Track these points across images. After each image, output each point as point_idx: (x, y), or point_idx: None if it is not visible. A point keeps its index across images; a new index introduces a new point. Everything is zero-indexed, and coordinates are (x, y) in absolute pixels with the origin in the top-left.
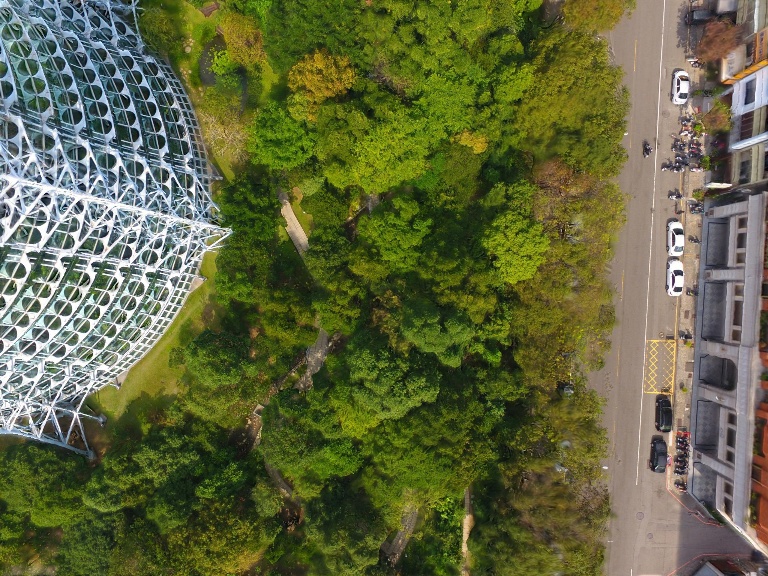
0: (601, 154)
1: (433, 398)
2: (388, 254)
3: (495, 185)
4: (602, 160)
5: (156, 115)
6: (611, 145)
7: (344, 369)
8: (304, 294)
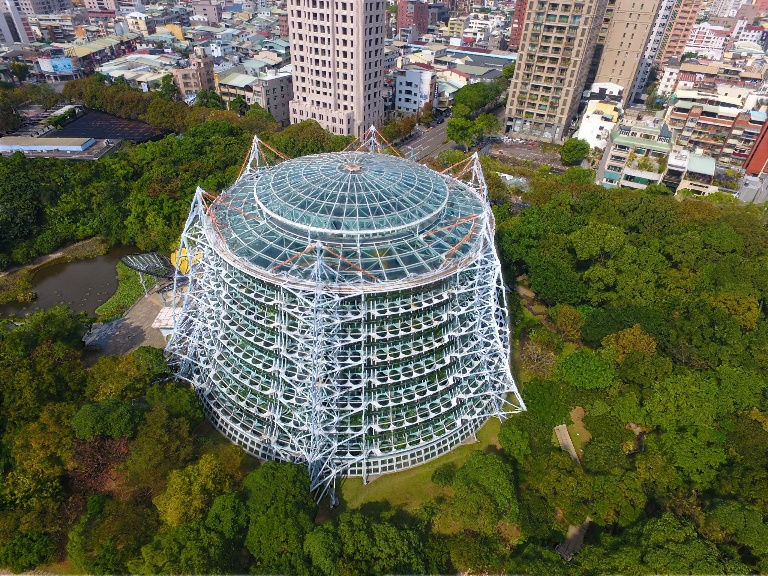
0: None
1: None
2: (685, 459)
3: None
4: None
5: None
6: None
7: None
8: None
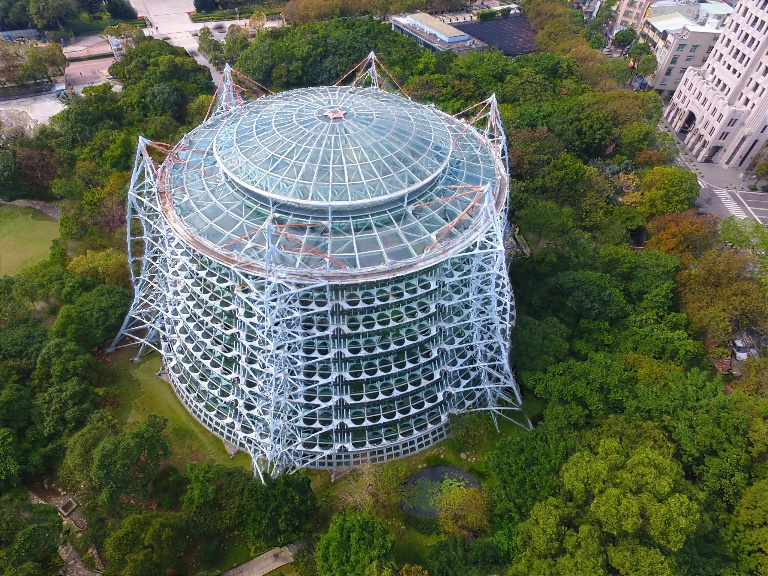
0: None
1: None
2: None
3: None
4: None
5: (383, 419)
6: None
7: None
8: (179, 573)
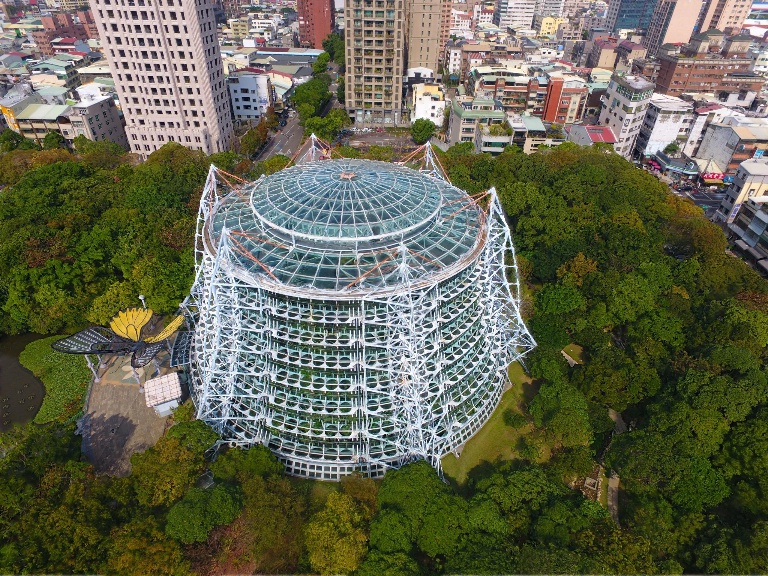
0: (765, 287)
1: (765, 394)
2: (664, 334)
3: (711, 302)
4: (767, 291)
5: None
6: (767, 283)
7: (668, 409)
8: None
